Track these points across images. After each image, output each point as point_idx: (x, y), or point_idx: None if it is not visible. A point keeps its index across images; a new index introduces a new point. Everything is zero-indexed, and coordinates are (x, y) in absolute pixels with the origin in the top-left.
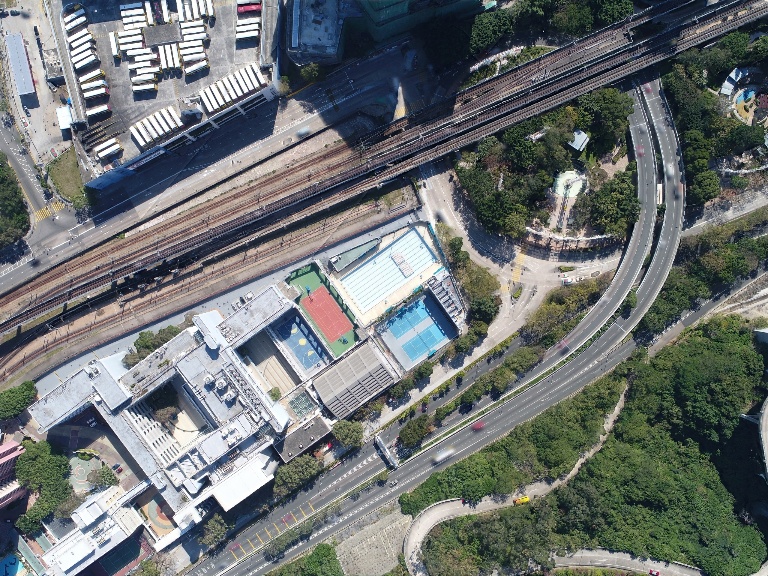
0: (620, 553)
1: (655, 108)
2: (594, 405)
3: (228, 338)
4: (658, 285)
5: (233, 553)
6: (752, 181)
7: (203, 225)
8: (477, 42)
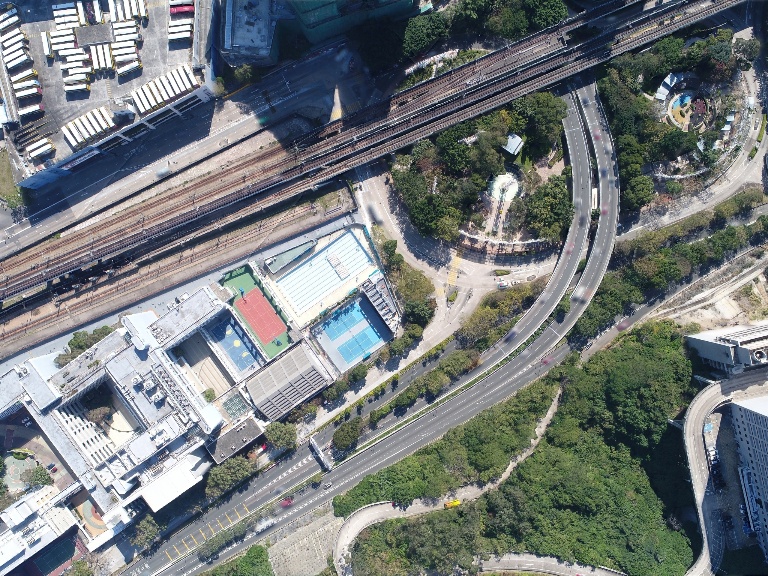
0: (547, 557)
1: (591, 112)
2: (526, 409)
3: (159, 339)
4: (592, 290)
5: (167, 554)
6: (686, 186)
7: (138, 226)
8: (410, 45)
